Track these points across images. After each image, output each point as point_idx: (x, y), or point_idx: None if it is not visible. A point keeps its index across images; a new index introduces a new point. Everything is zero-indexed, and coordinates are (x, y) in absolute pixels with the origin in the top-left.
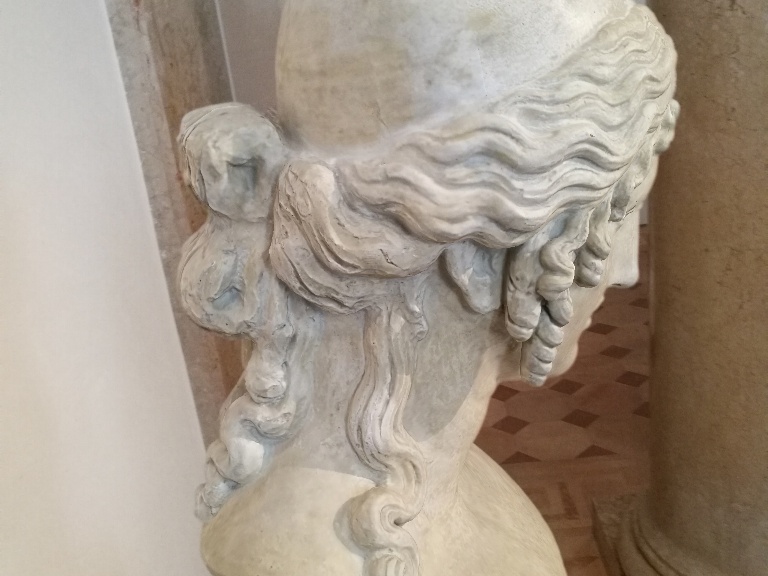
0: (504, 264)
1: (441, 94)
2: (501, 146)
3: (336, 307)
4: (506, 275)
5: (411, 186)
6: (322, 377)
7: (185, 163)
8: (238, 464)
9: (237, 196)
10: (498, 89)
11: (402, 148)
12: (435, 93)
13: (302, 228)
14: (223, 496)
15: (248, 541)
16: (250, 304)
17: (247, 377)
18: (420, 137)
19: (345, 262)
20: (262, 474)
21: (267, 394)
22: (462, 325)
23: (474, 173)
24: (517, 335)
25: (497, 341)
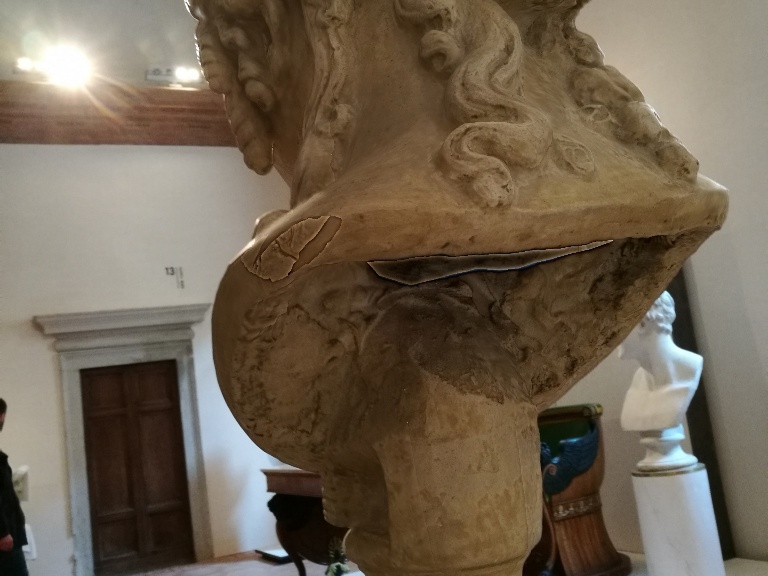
0: None
1: None
2: None
3: None
4: None
5: None
6: None
7: None
8: None
9: None
10: None
11: None
12: None
13: None
14: None
15: None
16: None
17: None
18: None
19: None
20: None
21: None
22: None
23: None
24: None
25: None
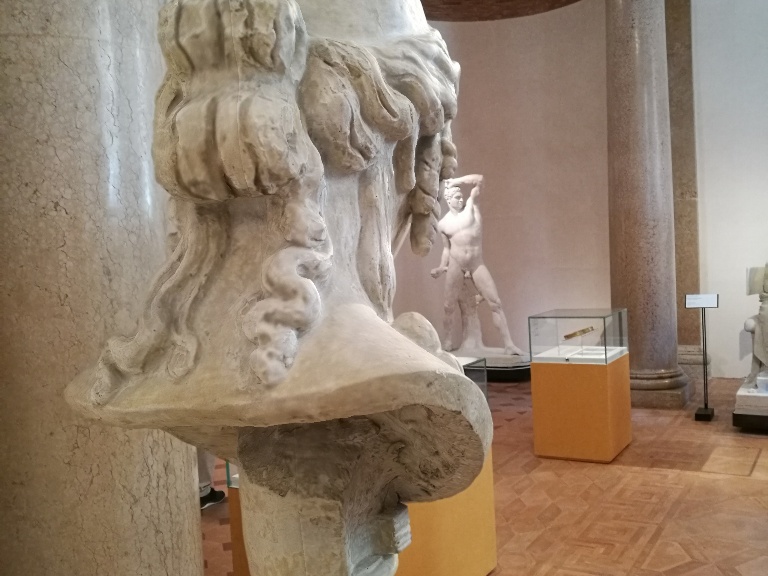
0: (415, 155)
1: (406, 17)
2: (444, 57)
3: (362, 159)
4: (418, 162)
5: (417, 65)
6: (334, 233)
7: (226, 22)
8: (316, 300)
9: (293, 53)
10: (422, 28)
11: (399, 43)
12: (404, 15)
13: (355, 83)
14: (296, 343)
15: (371, 350)
16: (302, 151)
17: (301, 221)
18: (410, 38)
19: (391, 110)
20: (323, 315)
21: (321, 235)
22: (393, 202)
23: (436, 69)
24: (432, 204)
25: (396, 225)
